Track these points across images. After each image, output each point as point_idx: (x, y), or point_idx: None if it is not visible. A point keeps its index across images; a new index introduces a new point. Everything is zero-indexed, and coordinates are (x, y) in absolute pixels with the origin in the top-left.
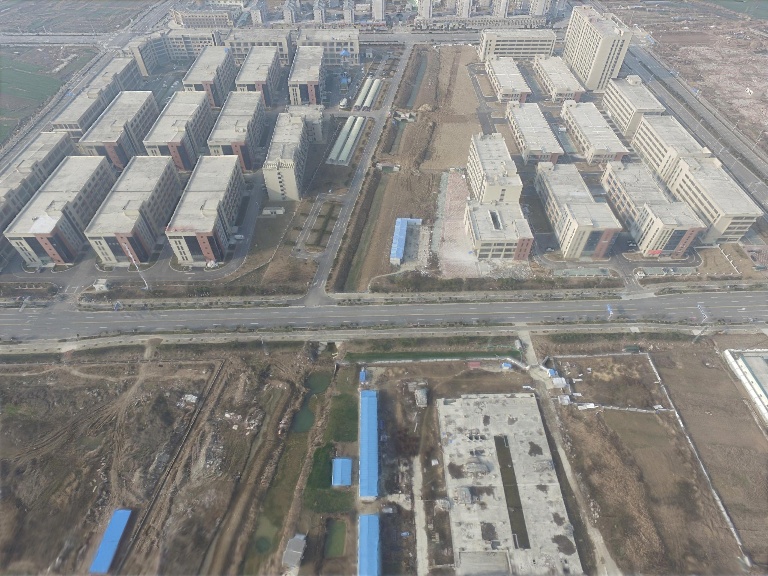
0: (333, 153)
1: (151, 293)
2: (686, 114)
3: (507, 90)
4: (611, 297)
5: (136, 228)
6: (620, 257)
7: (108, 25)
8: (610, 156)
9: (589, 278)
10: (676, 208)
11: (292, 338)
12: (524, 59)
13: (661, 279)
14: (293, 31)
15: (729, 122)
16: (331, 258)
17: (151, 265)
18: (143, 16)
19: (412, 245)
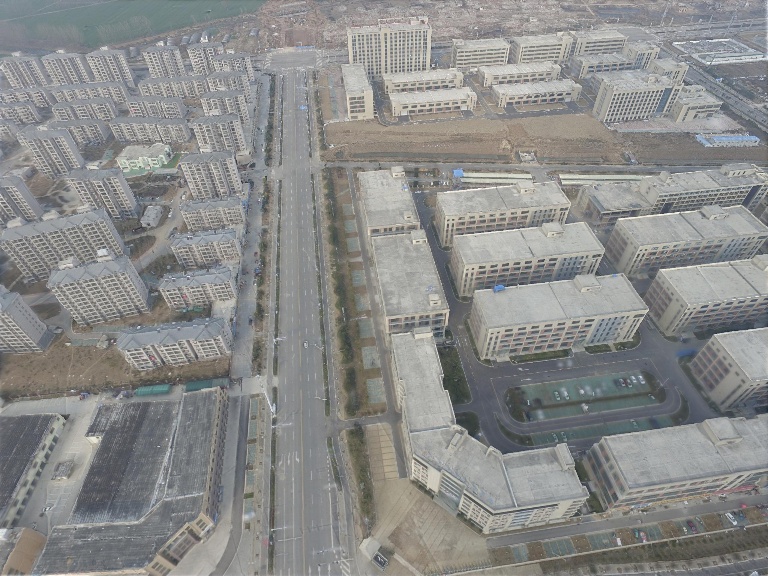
0: None
1: None
2: None
3: None
4: None
5: None
6: None
7: None
8: None
9: None
10: (633, 46)
11: None
12: None
13: None
14: (262, 288)
15: None
16: None
17: None
18: None
19: None
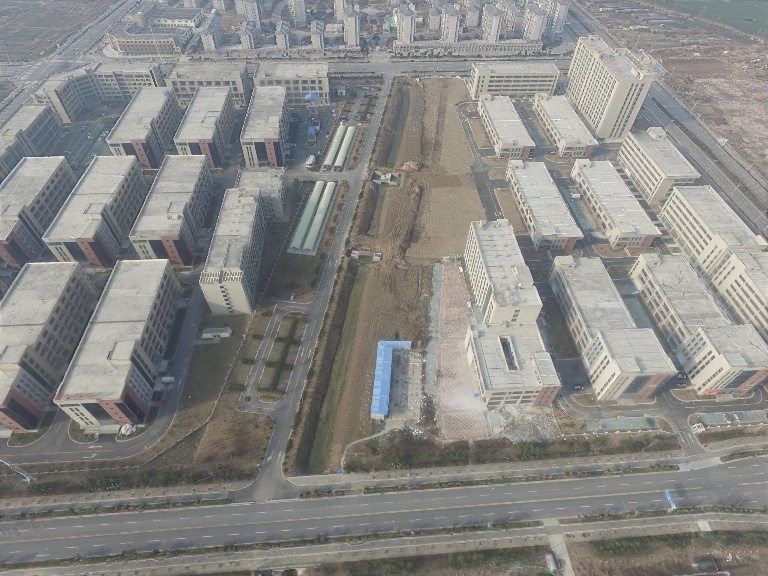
0: (296, 238)
1: (34, 489)
2: (716, 171)
3: (507, 144)
4: (666, 468)
5: (13, 392)
6: (668, 396)
7: (30, 51)
8: (638, 238)
9: (633, 435)
10: (739, 334)
11: (233, 566)
12: (522, 96)
13: (725, 433)
14: (252, 59)
15: (767, 182)
16: (292, 411)
17: (41, 434)
18: (74, 39)
19: (399, 384)
